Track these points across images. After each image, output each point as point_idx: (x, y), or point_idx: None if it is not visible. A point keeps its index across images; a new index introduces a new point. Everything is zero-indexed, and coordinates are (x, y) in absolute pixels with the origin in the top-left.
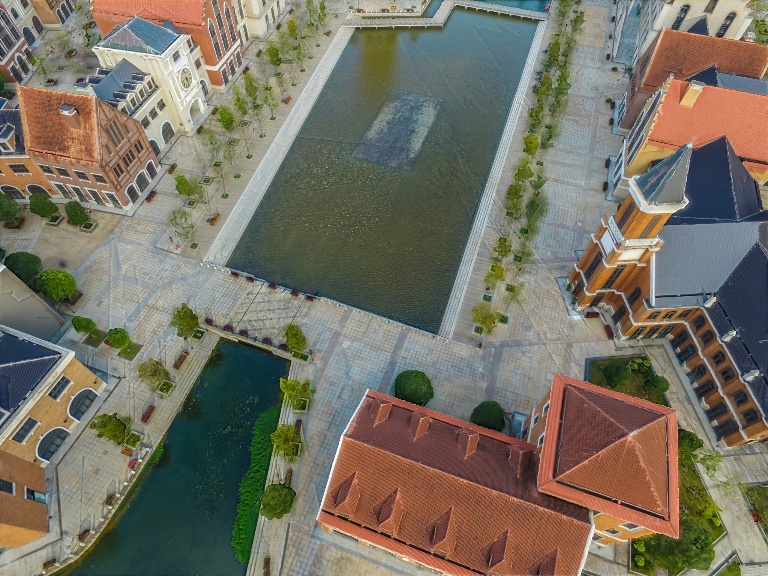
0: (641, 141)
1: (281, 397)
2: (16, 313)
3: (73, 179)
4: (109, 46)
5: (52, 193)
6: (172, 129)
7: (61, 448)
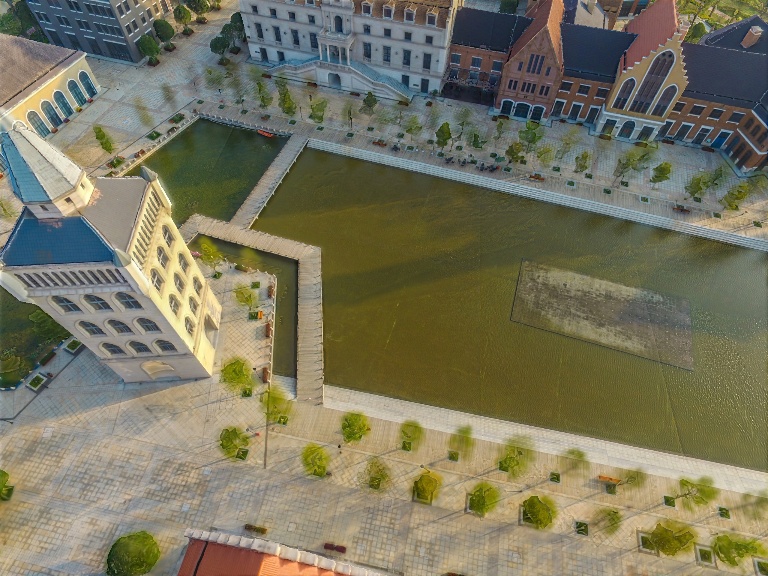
0: (674, 91)
1: None
2: None
3: None
4: None
5: None
6: None
7: None
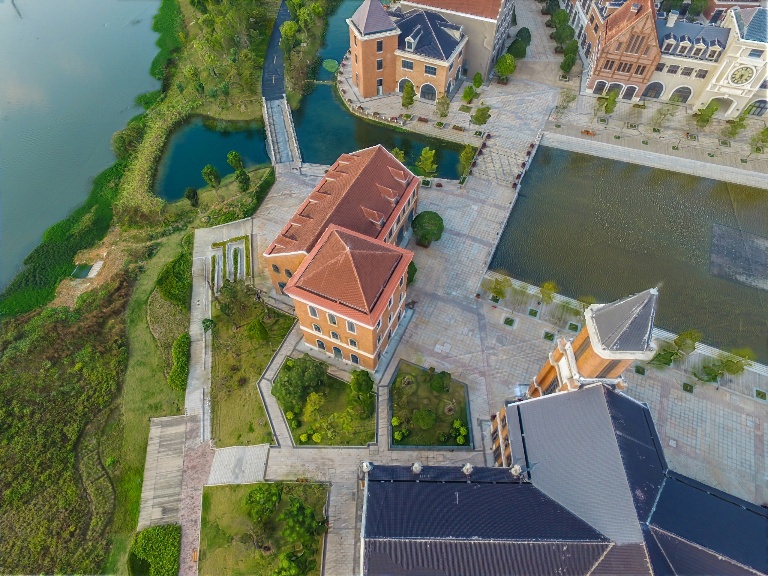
0: None
1: None
2: (477, 49)
3: (596, 52)
4: (737, 14)
5: None
6: (688, 98)
7: None
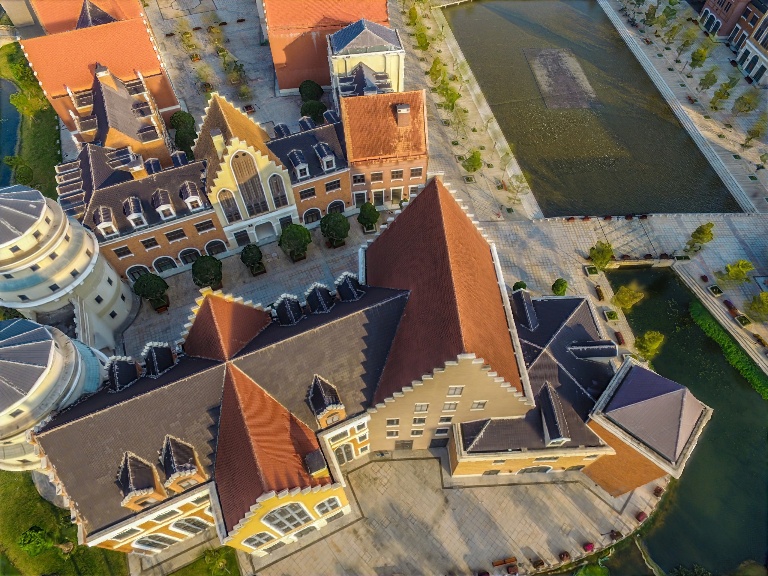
0: None
1: (689, 293)
2: None
3: (383, 182)
4: (348, 52)
5: (347, 206)
6: None
7: None
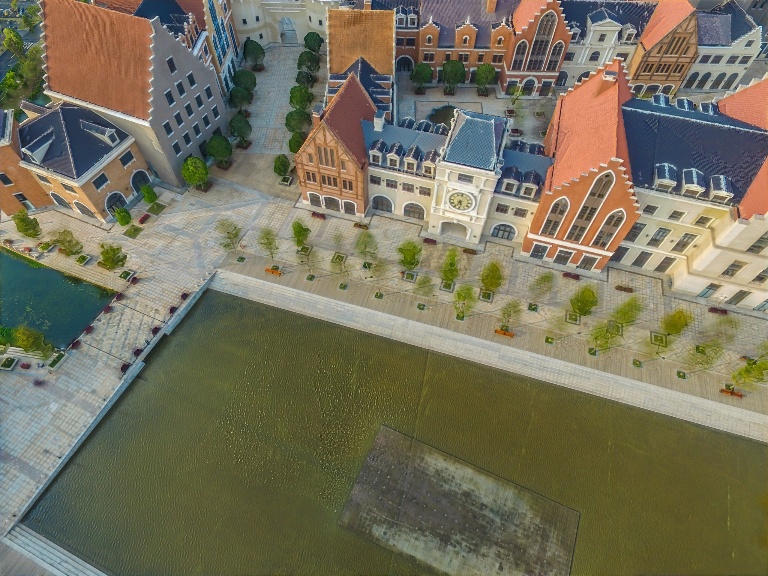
0: None
1: None
2: (152, 151)
3: None
4: None
5: None
6: (424, 215)
7: (66, 209)
